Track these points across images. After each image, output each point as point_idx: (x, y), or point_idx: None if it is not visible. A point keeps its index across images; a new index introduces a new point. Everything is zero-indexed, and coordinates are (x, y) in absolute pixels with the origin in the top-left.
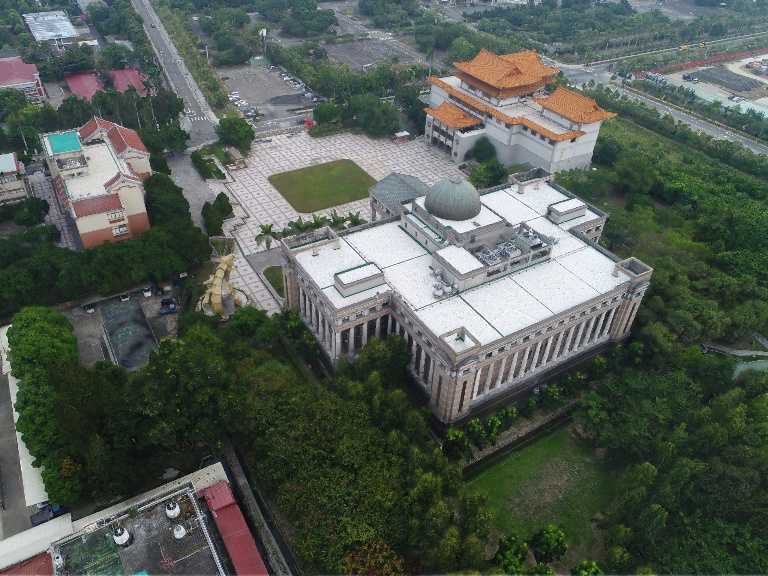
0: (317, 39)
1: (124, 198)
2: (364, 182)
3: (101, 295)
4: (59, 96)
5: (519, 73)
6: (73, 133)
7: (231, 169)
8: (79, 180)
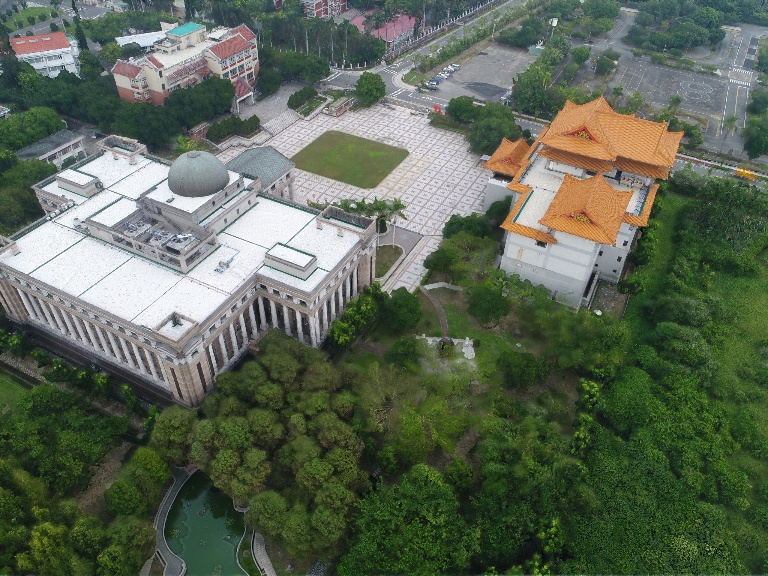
0: (641, 53)
1: (147, 74)
2: (373, 173)
3: (103, 130)
4: (342, 19)
5: (593, 139)
6: (201, 26)
7: (324, 112)
8: (160, 55)
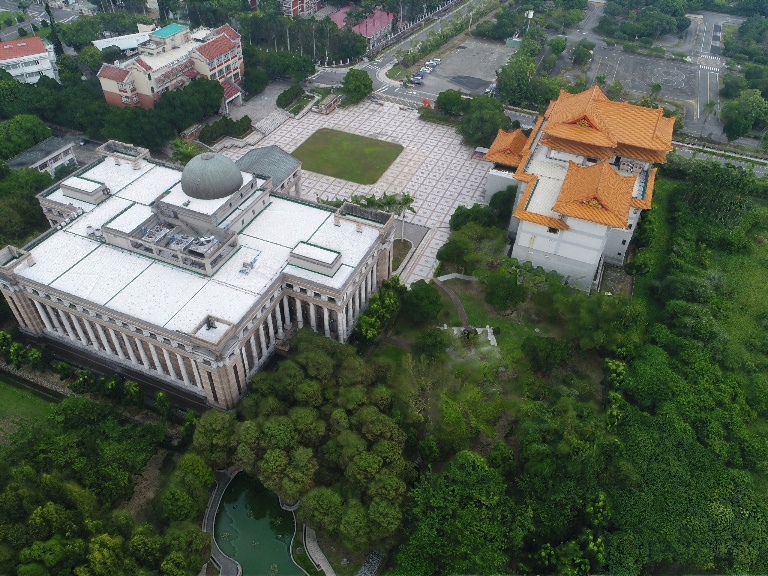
0: (614, 42)
1: (135, 77)
2: (371, 169)
3: (91, 136)
4: (319, 17)
5: (593, 126)
6: (185, 27)
7: (313, 110)
8: (145, 57)
